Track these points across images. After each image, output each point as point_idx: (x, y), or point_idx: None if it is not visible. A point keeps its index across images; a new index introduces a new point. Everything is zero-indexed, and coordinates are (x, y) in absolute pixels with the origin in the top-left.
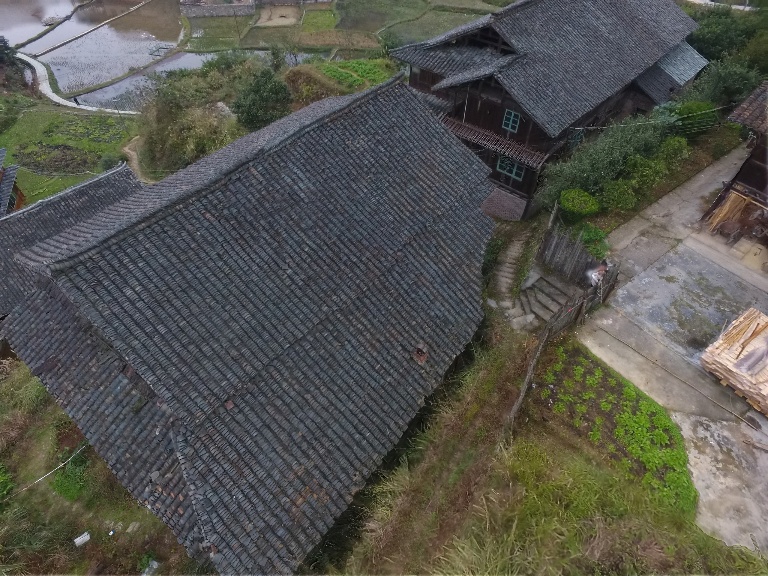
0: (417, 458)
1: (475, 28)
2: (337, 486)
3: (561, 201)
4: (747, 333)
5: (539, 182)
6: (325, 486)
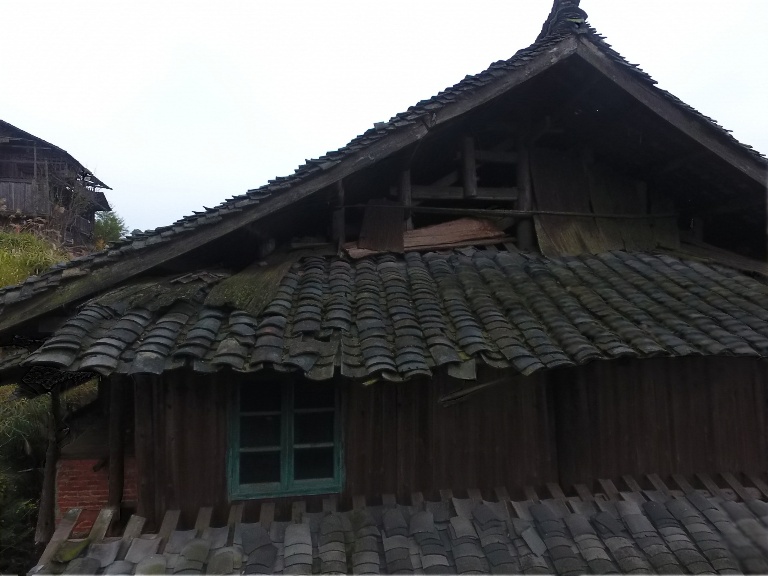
0: None
1: None
2: None
3: None
4: None
5: None
6: None
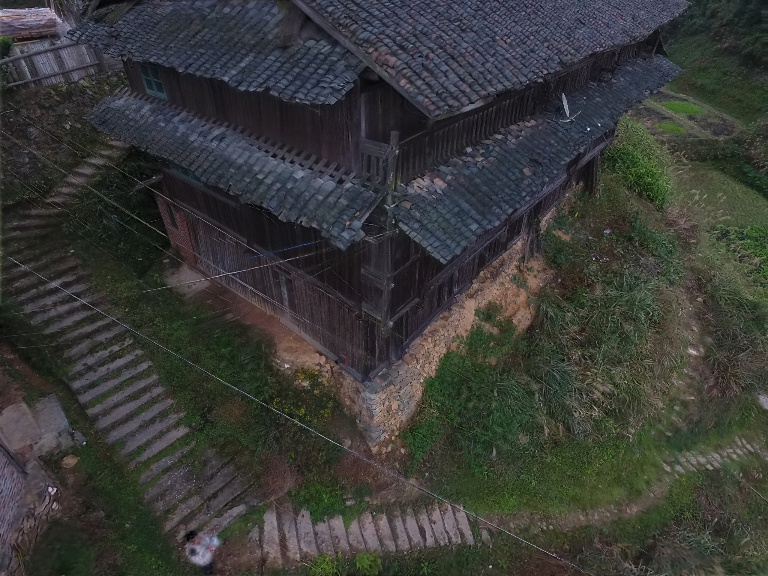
0: None
1: None
2: None
3: (3, 42)
4: (2, 17)
5: None
6: None
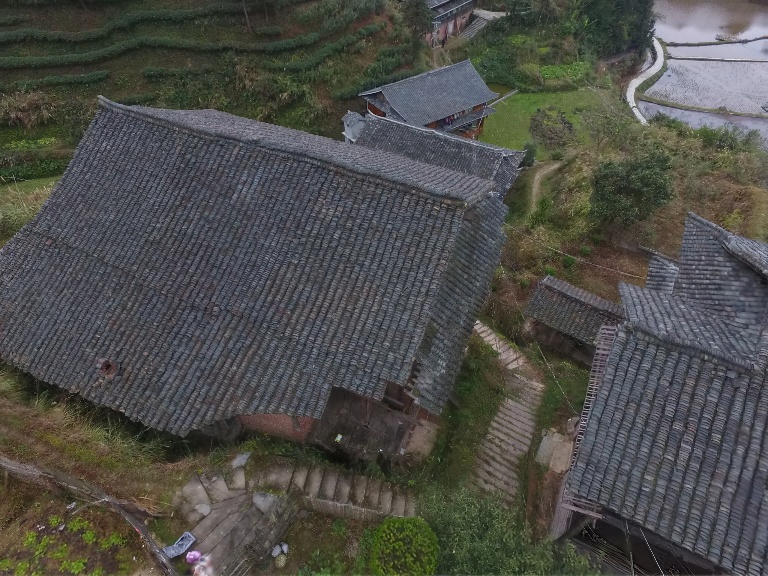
0: (29, 403)
1: (761, 268)
2: (4, 341)
3: None
4: None
5: (596, 540)
6: (3, 332)
